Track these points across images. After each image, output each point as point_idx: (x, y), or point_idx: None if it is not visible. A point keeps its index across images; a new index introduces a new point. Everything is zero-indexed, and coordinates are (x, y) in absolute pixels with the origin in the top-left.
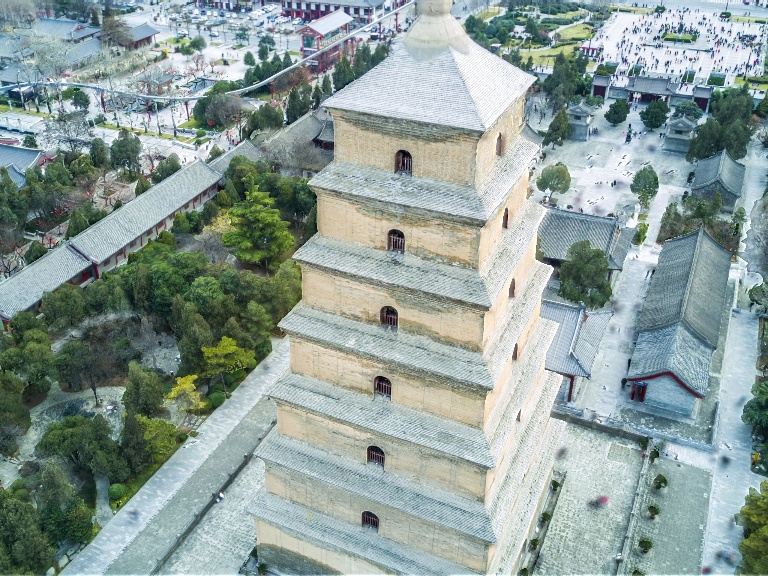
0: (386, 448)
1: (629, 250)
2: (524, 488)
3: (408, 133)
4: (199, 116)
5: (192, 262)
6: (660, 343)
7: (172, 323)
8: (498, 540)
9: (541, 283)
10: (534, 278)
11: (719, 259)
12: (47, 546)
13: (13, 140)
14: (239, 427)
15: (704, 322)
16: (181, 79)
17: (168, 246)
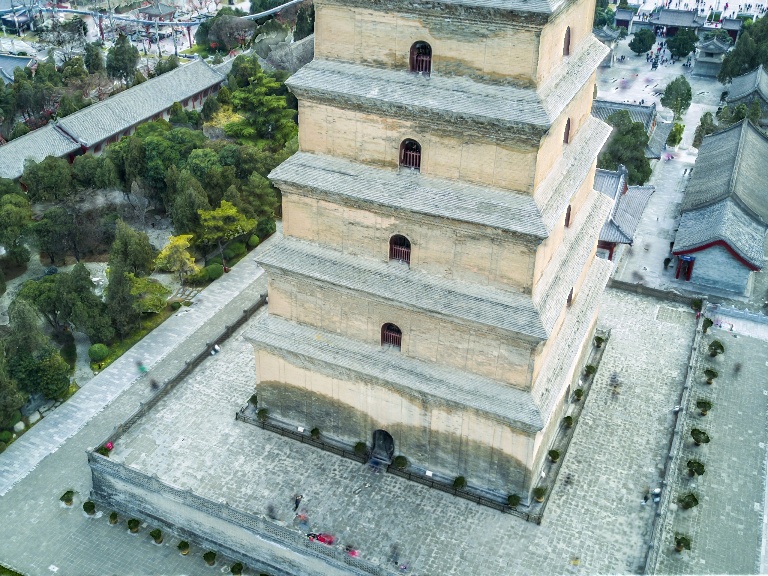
0: (413, 235)
1: (663, 152)
2: (570, 315)
3: None
4: (202, 40)
5: (189, 137)
6: (708, 218)
7: (166, 201)
8: (543, 358)
9: (597, 55)
10: (589, 48)
11: (765, 150)
12: (15, 392)
13: (4, 53)
14: (238, 298)
15: (755, 202)
16: (184, 15)
17: (164, 126)
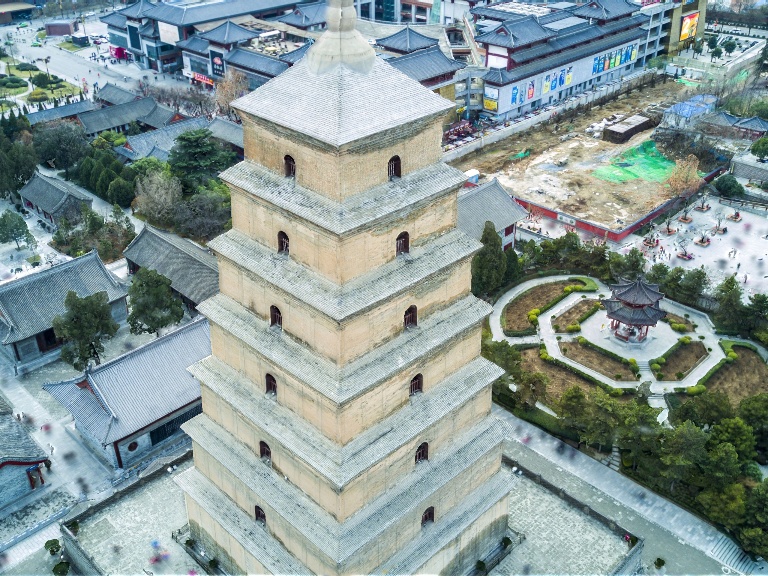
0: (430, 437)
1: None
2: None
3: (399, 137)
4: None
5: None
6: None
7: None
8: None
9: None
10: None
11: (179, 240)
12: None
13: None
14: None
15: None
16: None
17: None
